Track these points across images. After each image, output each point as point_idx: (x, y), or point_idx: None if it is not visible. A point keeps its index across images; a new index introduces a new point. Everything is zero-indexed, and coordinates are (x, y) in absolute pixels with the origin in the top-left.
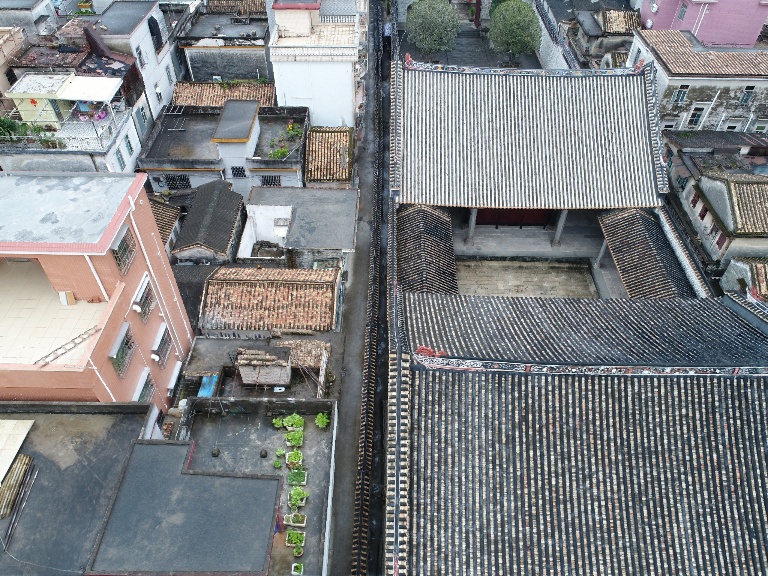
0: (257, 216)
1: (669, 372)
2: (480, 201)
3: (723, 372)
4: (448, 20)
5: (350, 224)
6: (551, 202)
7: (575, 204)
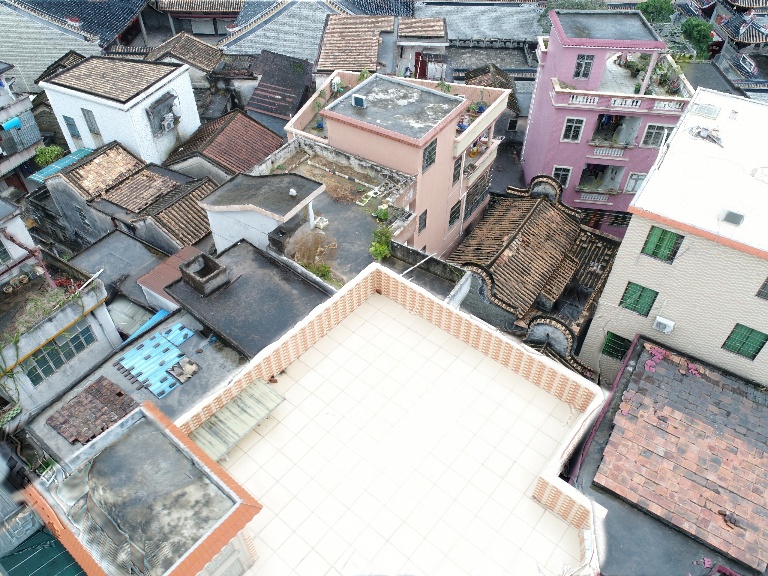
0: None
1: None
2: (245, 5)
3: None
4: (552, 2)
5: None
6: None
7: None
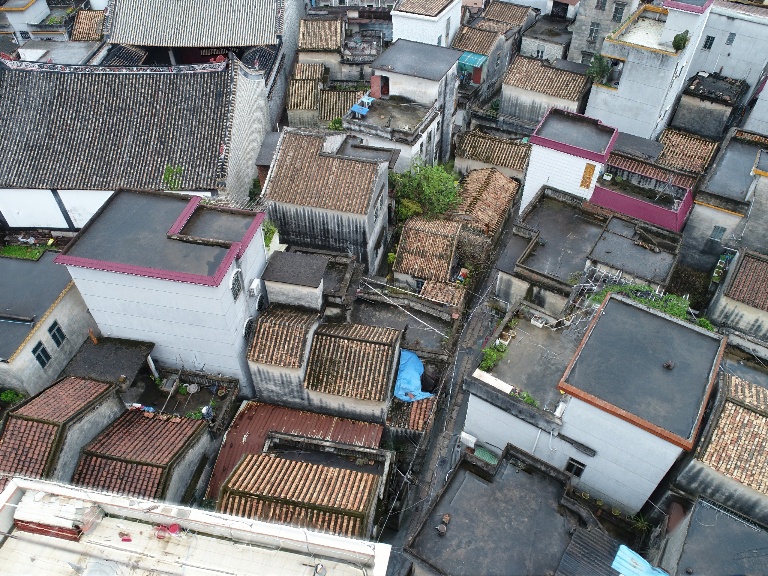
0: (27, 58)
1: (136, 70)
2: (163, 42)
3: (164, 70)
4: None
5: (79, 58)
6: (209, 42)
7: (224, 43)
